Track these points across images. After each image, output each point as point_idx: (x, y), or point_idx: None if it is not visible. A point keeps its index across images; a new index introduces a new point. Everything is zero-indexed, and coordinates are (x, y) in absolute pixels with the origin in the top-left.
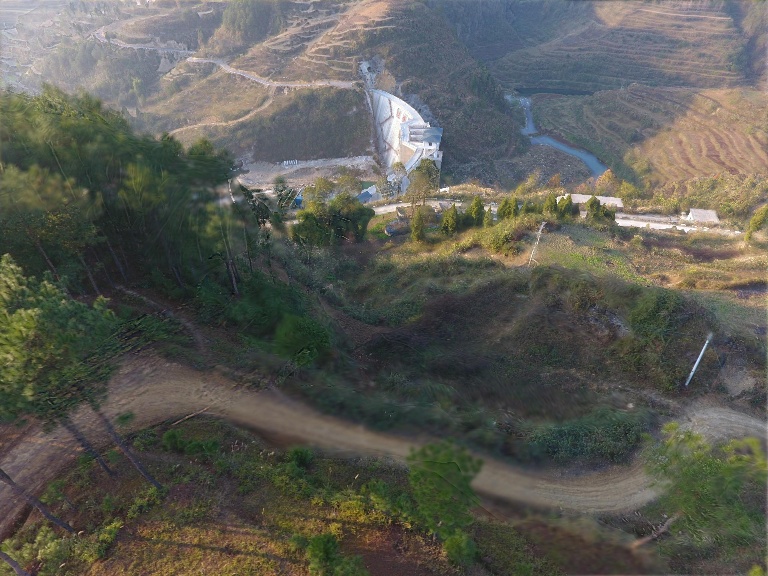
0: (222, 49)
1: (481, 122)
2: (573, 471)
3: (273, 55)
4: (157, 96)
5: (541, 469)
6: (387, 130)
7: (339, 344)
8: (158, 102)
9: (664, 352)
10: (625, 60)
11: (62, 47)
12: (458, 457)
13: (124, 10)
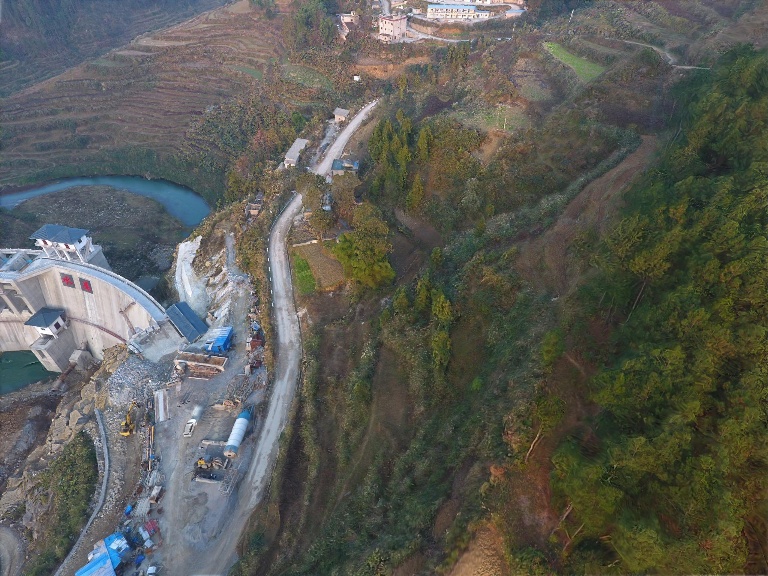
0: None
1: None
2: None
3: None
4: None
5: None
6: None
7: None
8: None
9: None
10: None
11: None
12: None
13: None
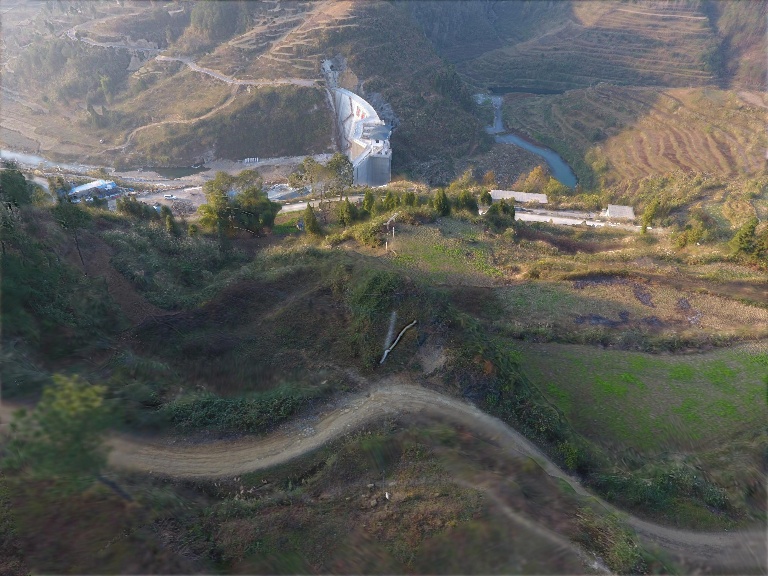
0: (189, 47)
1: (443, 120)
2: (193, 439)
3: (238, 53)
4: (124, 94)
5: (153, 436)
6: (348, 128)
7: (106, 326)
8: (125, 100)
9: (369, 331)
10: (599, 59)
11: (35, 45)
12: (67, 423)
13: (100, 9)
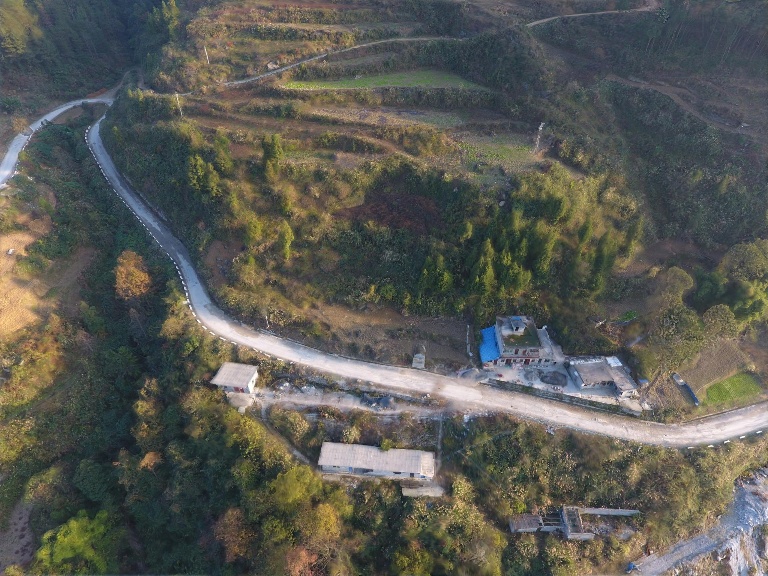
0: None
1: None
2: None
3: None
4: None
5: None
6: None
7: None
8: None
9: None
10: None
11: None
12: None
13: None
